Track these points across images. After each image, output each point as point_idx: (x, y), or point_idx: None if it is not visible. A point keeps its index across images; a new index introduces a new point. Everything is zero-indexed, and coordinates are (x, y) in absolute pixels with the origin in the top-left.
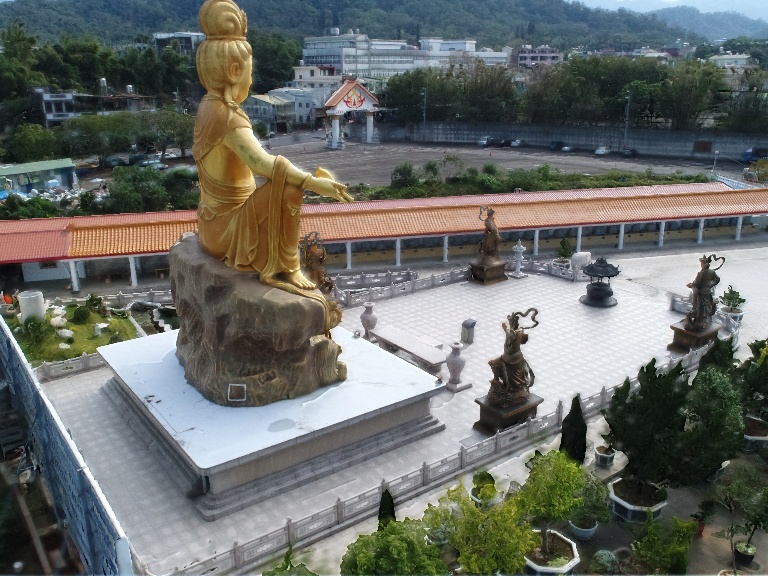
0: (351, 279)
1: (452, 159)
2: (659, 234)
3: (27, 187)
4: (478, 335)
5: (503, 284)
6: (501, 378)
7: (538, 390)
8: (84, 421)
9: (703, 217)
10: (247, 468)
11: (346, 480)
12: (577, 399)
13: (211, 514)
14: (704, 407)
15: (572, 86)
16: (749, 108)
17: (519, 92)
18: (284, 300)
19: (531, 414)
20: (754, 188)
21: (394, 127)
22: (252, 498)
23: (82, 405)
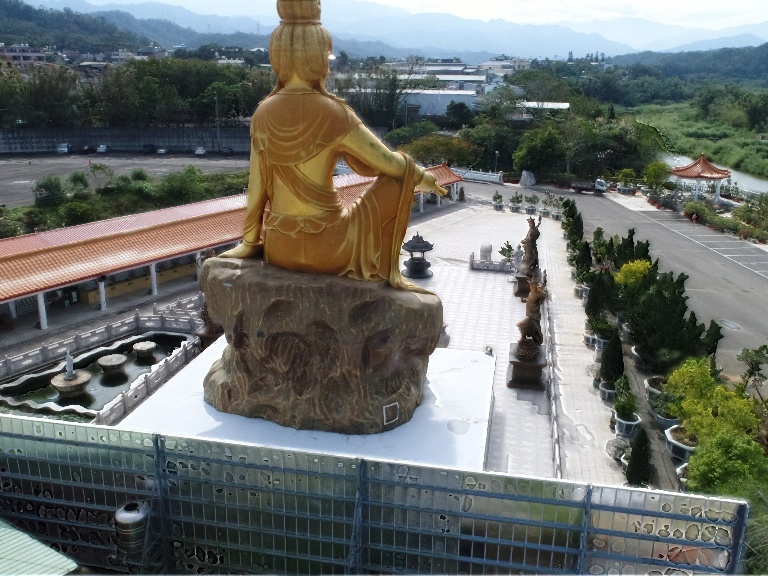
0: (190, 302)
1: (100, 168)
2: None
3: None
4: None
5: None
6: (530, 335)
7: (496, 347)
8: None
9: None
10: None
11: (504, 459)
12: None
13: None
14: None
15: (152, 87)
16: None
17: (88, 94)
18: (434, 300)
19: None
20: None
21: None
22: None
23: None
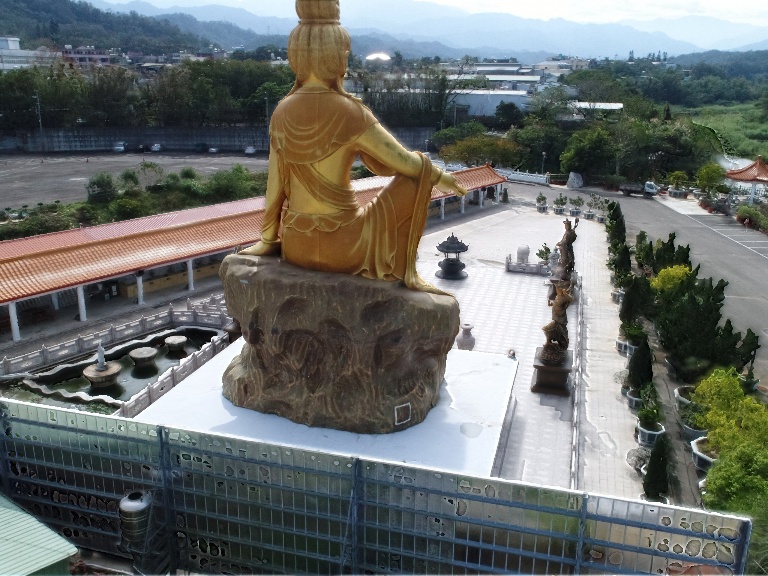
0: None
1: (151, 166)
2: None
3: None
4: None
5: None
6: (556, 340)
7: (524, 351)
8: None
9: (446, 196)
10: None
11: (520, 464)
12: None
13: None
14: None
15: (205, 88)
16: None
17: (144, 94)
18: (449, 302)
19: None
20: (463, 170)
21: None
22: None
23: None
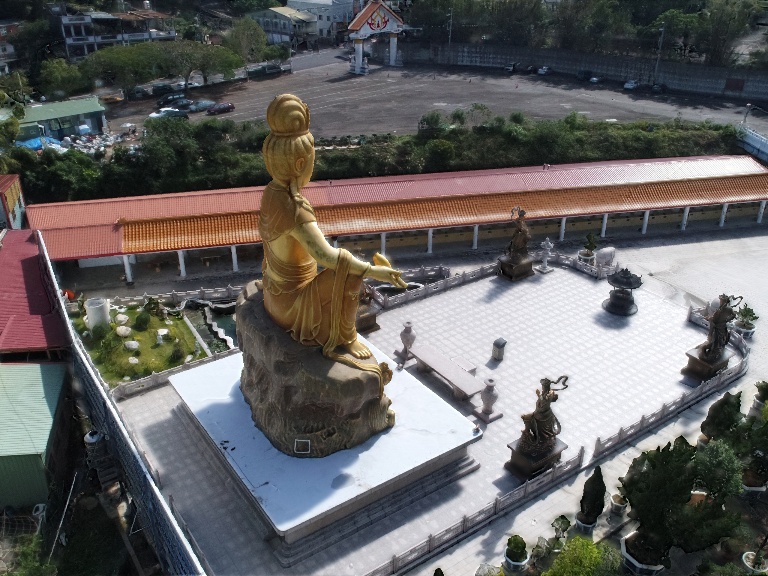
0: None
1: (480, 108)
2: None
3: (58, 132)
4: (507, 350)
5: (530, 281)
6: (532, 431)
7: (562, 422)
8: (164, 450)
9: (727, 203)
10: (315, 521)
11: (397, 525)
12: (599, 468)
13: (287, 562)
14: (709, 477)
15: (605, 12)
16: None
17: (549, 14)
18: (346, 377)
19: (556, 458)
20: None
21: (418, 48)
22: (320, 545)
23: (159, 430)
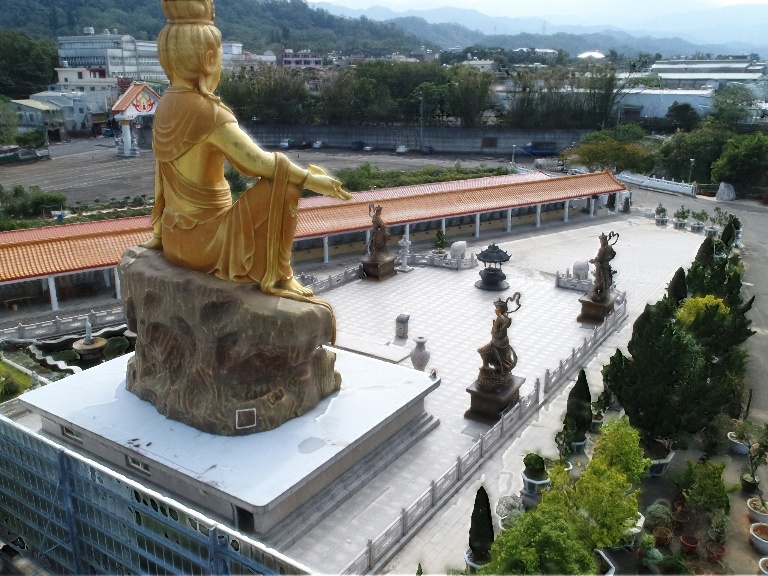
0: None
1: None
2: (507, 221)
3: None
4: (408, 329)
5: (396, 279)
6: (492, 364)
7: None
8: None
9: (541, 203)
10: (290, 498)
11: (380, 491)
12: None
13: None
14: (680, 363)
15: (366, 88)
16: (524, 107)
17: (313, 94)
18: (299, 309)
19: (516, 395)
20: None
21: None
22: (300, 529)
23: None
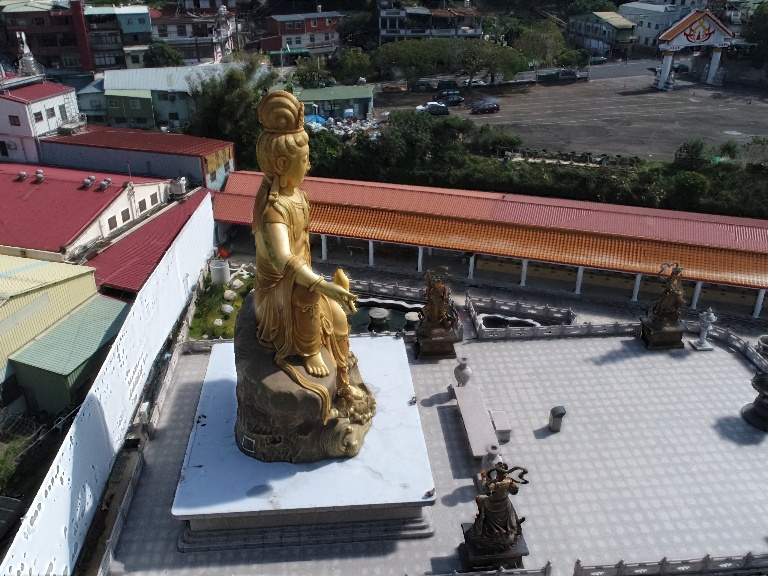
0: (505, 304)
1: (760, 142)
2: None
3: (330, 112)
4: (573, 423)
5: (671, 354)
6: None
7: (568, 525)
8: (182, 407)
9: None
10: (221, 519)
11: (303, 557)
12: None
13: (182, 547)
14: None
15: None
16: None
17: None
18: (279, 388)
19: (513, 561)
20: None
21: (748, 66)
22: (219, 544)
23: (192, 389)
